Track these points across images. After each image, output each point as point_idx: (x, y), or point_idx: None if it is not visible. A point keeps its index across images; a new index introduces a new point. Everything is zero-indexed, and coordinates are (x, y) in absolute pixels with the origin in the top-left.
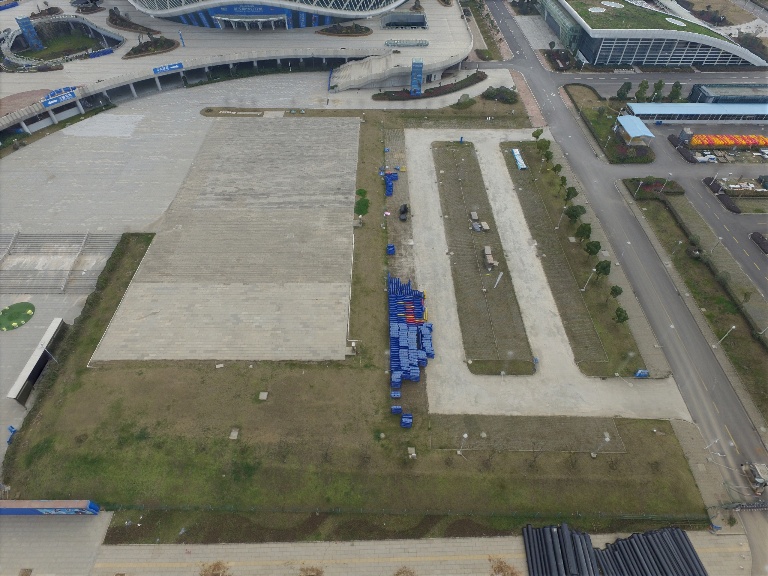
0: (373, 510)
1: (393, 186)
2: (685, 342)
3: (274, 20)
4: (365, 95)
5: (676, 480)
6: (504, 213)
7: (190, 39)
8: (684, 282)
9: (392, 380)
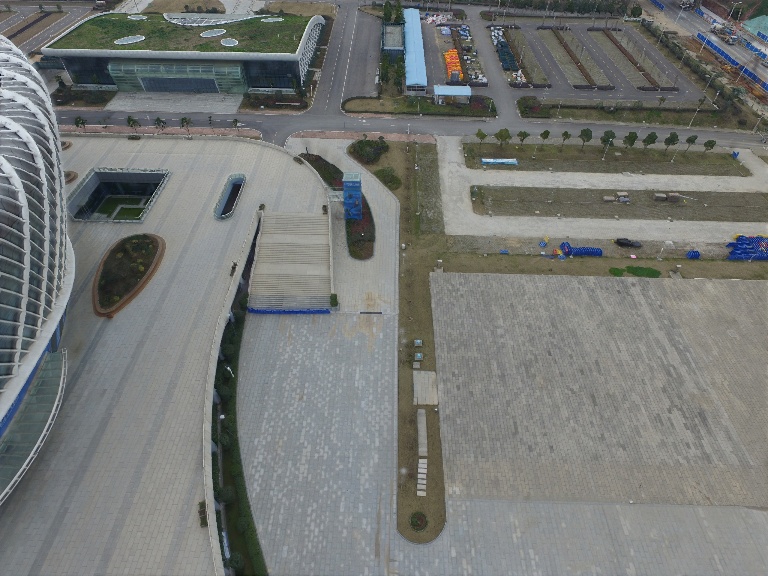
0: None
1: None
2: None
3: None
4: (352, 267)
5: None
6: (593, 182)
7: None
8: (637, 122)
9: None
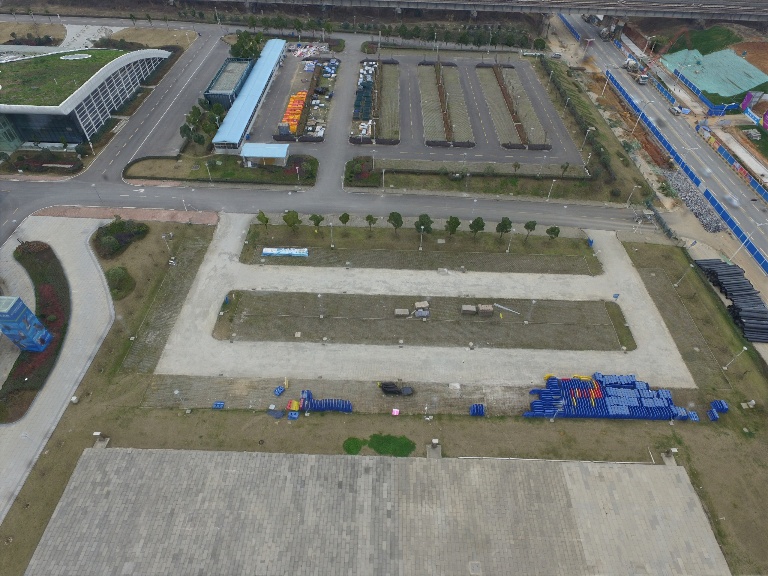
0: None
1: None
2: (547, 213)
3: None
4: None
5: (669, 251)
6: (394, 285)
7: None
8: (485, 193)
9: (687, 416)
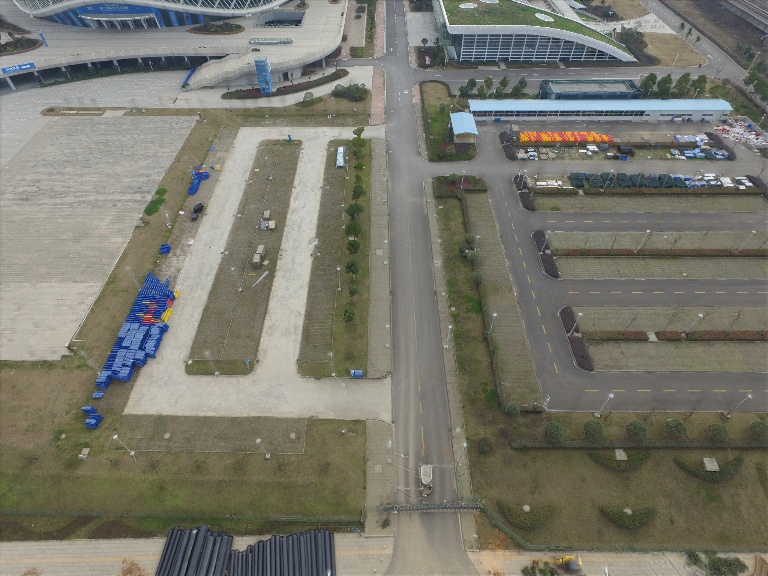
0: (27, 511)
1: (200, 185)
2: (419, 342)
3: (141, 19)
4: (216, 94)
5: (341, 481)
6: (299, 212)
7: (57, 39)
8: (445, 281)
9: (96, 380)
